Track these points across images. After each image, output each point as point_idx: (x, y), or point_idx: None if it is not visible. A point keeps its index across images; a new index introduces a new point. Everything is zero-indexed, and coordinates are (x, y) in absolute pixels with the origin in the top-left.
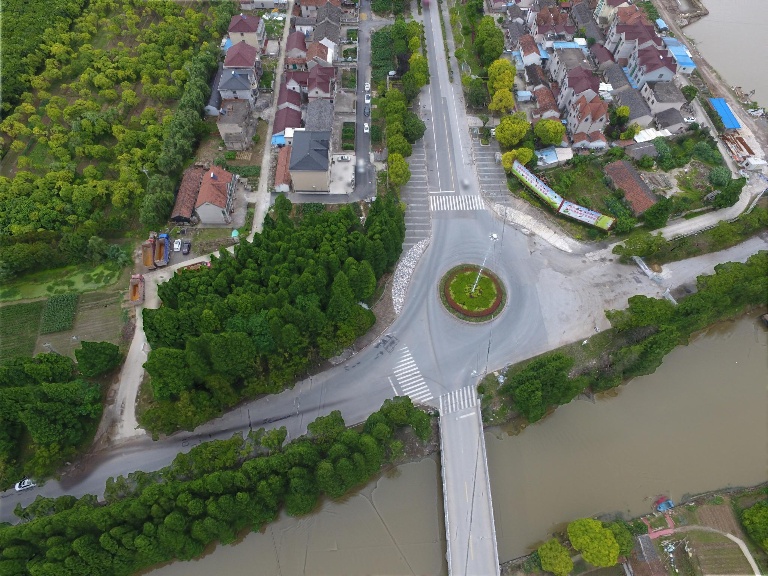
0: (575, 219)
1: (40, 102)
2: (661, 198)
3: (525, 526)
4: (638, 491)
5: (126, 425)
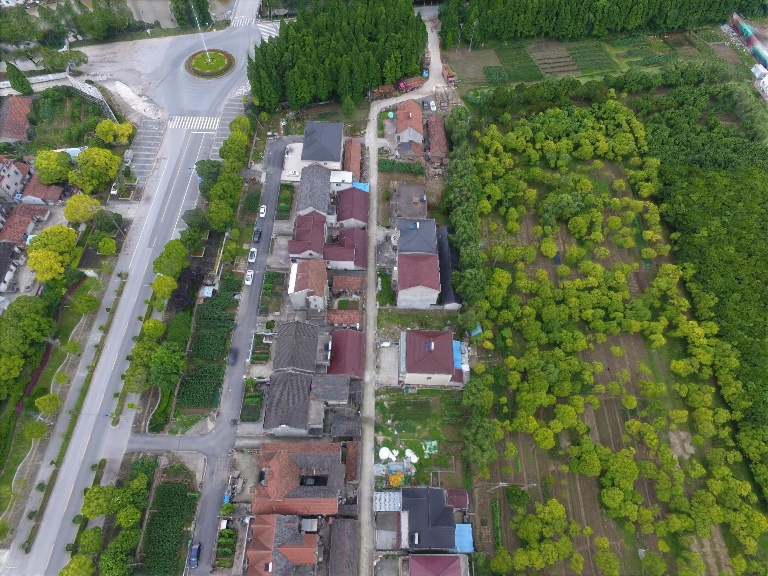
0: None
1: (655, 261)
2: None
3: (226, 8)
4: (162, 2)
5: (427, 26)
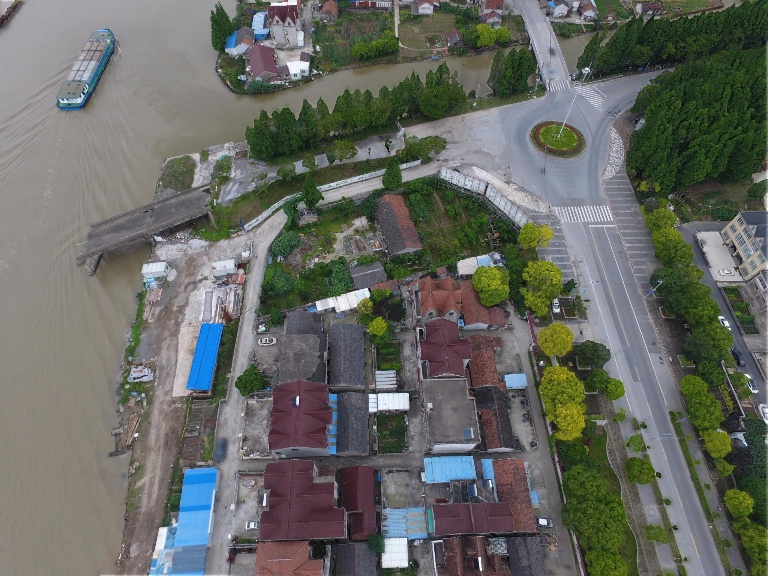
0: (468, 189)
1: None
2: (376, 203)
3: None
4: None
5: None
